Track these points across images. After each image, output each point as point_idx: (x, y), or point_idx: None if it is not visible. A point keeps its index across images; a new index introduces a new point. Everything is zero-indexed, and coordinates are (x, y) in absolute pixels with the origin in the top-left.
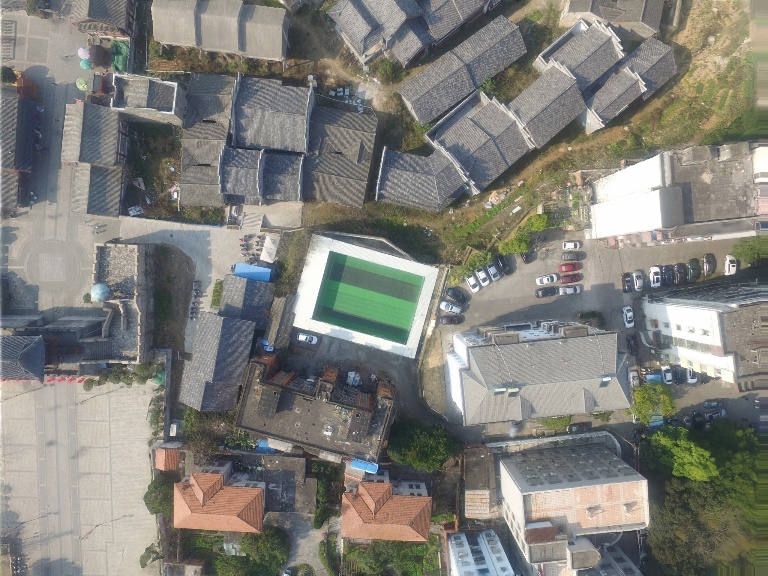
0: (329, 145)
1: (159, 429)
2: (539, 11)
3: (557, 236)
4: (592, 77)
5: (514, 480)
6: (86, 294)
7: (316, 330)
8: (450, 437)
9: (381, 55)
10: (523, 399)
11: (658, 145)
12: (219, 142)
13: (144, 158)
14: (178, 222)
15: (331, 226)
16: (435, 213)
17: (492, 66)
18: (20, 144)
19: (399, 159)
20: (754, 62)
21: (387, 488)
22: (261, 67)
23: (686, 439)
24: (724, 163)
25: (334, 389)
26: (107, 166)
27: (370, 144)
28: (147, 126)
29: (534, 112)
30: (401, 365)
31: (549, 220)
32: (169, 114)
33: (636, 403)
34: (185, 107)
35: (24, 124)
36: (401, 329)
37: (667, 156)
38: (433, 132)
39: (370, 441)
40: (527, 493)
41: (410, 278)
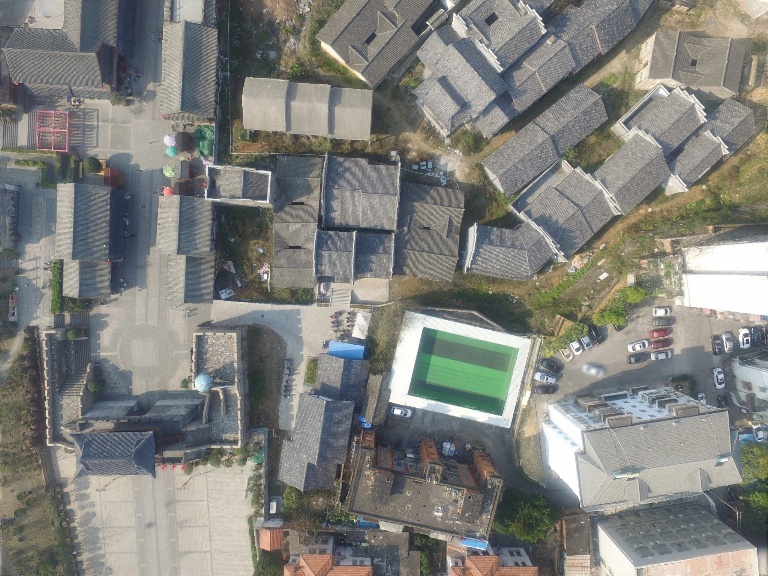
0: (417, 221)
1: None
2: (615, 74)
3: (647, 302)
4: (675, 143)
5: (622, 550)
6: (183, 380)
7: (412, 405)
8: (551, 506)
9: (462, 127)
10: (641, 481)
11: (737, 203)
12: (311, 225)
13: (232, 241)
14: (269, 303)
15: (421, 300)
16: (520, 280)
17: (575, 135)
18: (111, 235)
19: (490, 234)
20: None
21: (494, 561)
22: (344, 144)
23: None
24: None
25: None
26: (203, 256)
27: (458, 219)
28: (235, 210)
29: (621, 182)
30: (495, 433)
31: None
32: (264, 203)
33: None
34: (275, 191)
35: (114, 215)
36: (493, 398)
37: None
38: (517, 202)
39: (480, 519)
40: (641, 567)
41: (501, 348)
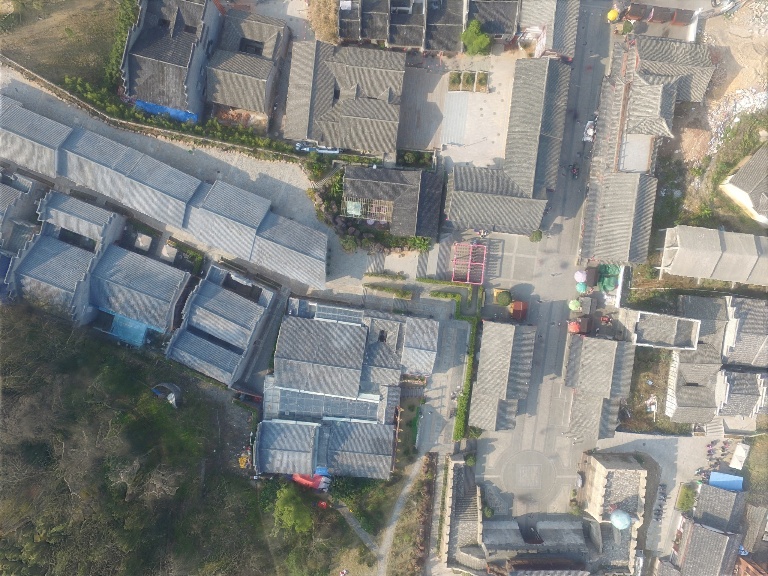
0: None
1: None
2: None
3: None
4: None
5: None
6: (578, 508)
7: None
8: None
9: None
10: None
11: None
12: (715, 366)
13: None
14: (655, 433)
15: None
16: None
17: None
18: None
19: None
20: None
21: None
22: None
23: None
24: None
25: None
26: None
27: None
28: None
29: None
30: None
31: None
32: None
33: None
34: None
35: None
36: None
37: None
38: None
39: None
40: None
41: None
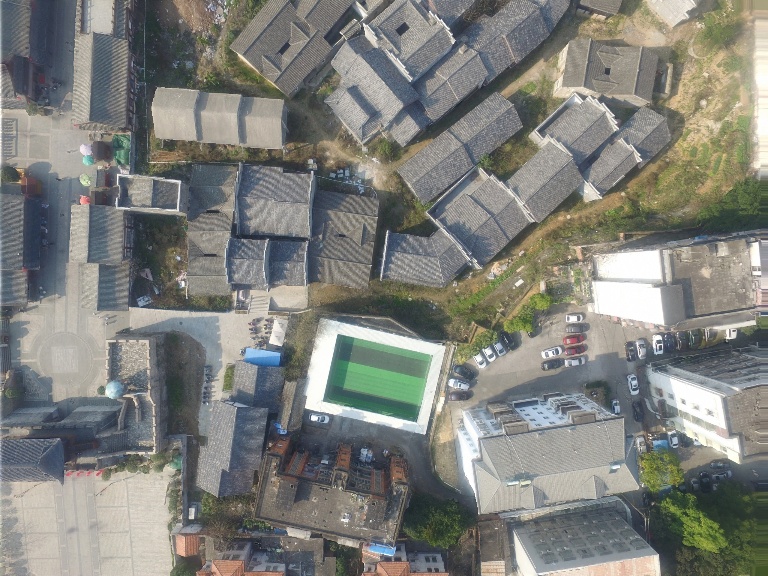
0: (332, 229)
1: (178, 513)
2: (533, 82)
3: (560, 309)
4: (588, 151)
5: (529, 556)
6: (100, 387)
7: (328, 411)
8: (464, 512)
9: (379, 135)
10: (535, 488)
11: (655, 210)
12: (224, 233)
13: (150, 248)
14: (187, 310)
15: (338, 307)
16: (439, 287)
17: (489, 143)
18: (27, 243)
19: (402, 242)
20: (746, 126)
21: (405, 567)
22: (261, 153)
23: (695, 508)
24: (722, 258)
25: (349, 477)
26: (115, 264)
27: (373, 226)
28: (152, 218)
29: (533, 190)
30: (412, 439)
31: (552, 296)
32: (174, 211)
33: (644, 473)
34: (189, 200)
35: (30, 223)
36: (411, 404)
37: (667, 254)
38: (434, 209)
39: (387, 526)
40: (542, 573)
41: (417, 354)
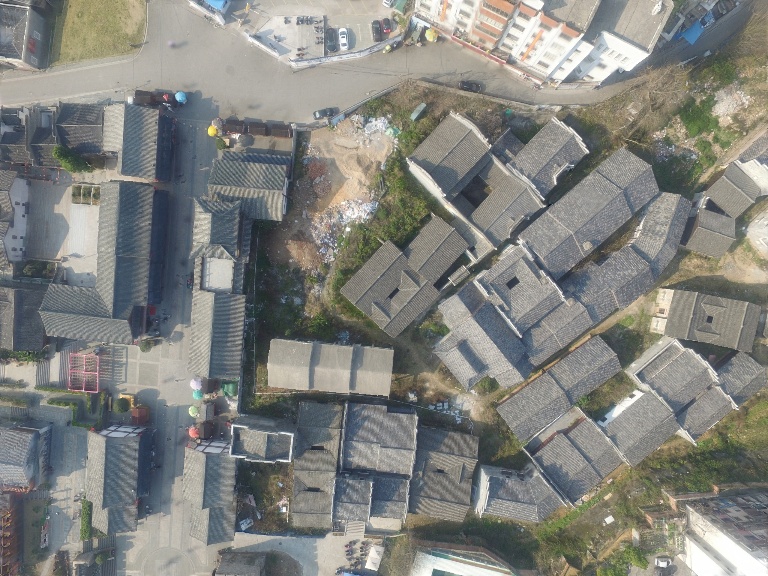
0: (432, 465)
1: None
2: (631, 316)
3: None
4: (686, 400)
5: None
6: None
7: None
8: None
9: None
10: None
11: (744, 446)
12: (329, 473)
13: (253, 474)
14: (287, 534)
15: (432, 535)
16: None
17: (589, 386)
18: (139, 474)
19: (501, 487)
20: None
21: None
22: None
23: None
24: None
25: None
26: None
27: (471, 465)
28: None
29: (632, 442)
30: None
31: (645, 547)
32: None
33: None
34: (296, 439)
35: (142, 454)
36: None
37: None
38: None
39: None
40: None
41: None
